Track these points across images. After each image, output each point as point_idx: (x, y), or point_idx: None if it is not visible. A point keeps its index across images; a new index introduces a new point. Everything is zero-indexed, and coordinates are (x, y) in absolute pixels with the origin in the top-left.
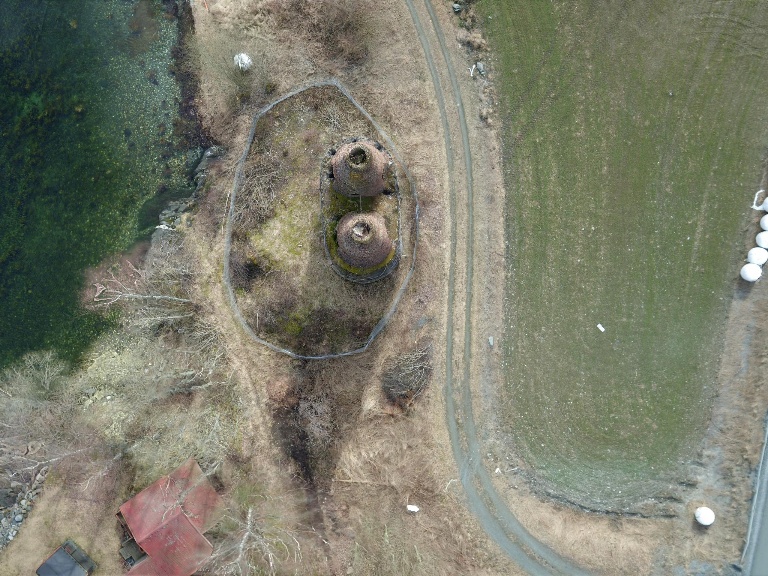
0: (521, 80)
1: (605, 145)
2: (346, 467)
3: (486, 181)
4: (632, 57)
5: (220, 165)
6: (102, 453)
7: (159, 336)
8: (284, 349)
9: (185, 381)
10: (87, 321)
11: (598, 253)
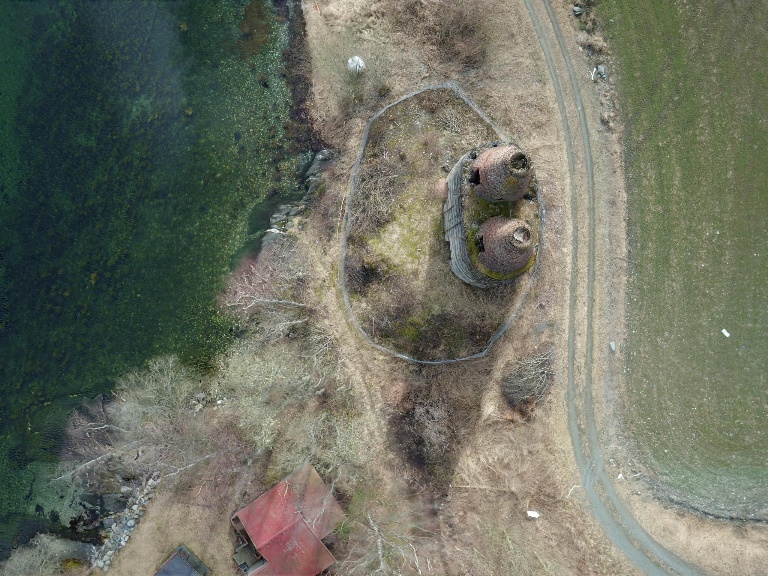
0: (643, 84)
1: (730, 149)
2: (464, 473)
3: (607, 185)
4: (758, 61)
5: (333, 168)
6: (214, 458)
7: (269, 340)
8: (400, 354)
9: (305, 386)
10: (196, 325)
11: (723, 258)
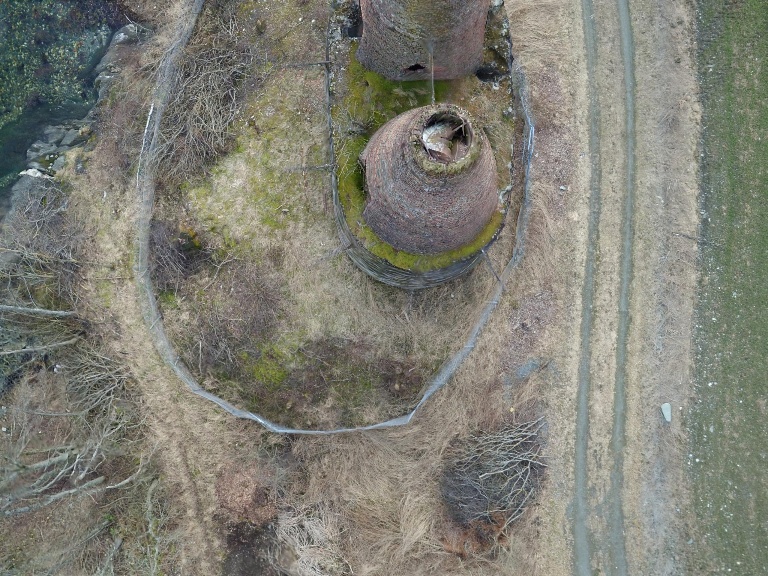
0: None
1: None
2: None
3: (661, 88)
4: None
5: (138, 56)
6: None
7: (22, 377)
8: (250, 412)
9: None
10: None
11: None
